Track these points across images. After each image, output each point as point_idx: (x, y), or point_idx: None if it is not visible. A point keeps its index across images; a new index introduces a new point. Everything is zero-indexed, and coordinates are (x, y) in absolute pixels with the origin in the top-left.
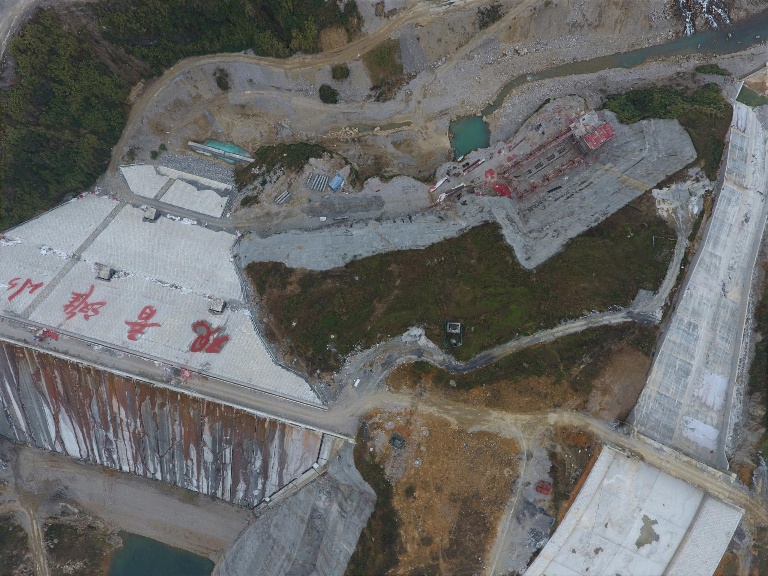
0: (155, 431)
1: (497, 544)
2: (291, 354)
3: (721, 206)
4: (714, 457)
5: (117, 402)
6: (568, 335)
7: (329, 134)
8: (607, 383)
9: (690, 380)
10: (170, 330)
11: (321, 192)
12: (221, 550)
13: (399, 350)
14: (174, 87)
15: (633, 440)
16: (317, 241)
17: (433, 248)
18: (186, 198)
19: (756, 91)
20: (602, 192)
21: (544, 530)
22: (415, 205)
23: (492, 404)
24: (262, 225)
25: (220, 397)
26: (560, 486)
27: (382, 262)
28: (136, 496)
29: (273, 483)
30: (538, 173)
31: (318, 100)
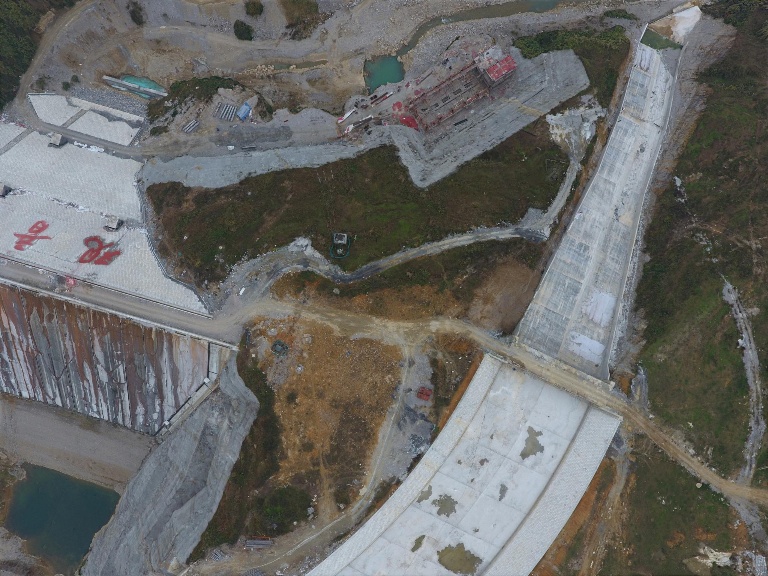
0: (47, 348)
1: (378, 450)
2: (180, 266)
3: (617, 136)
4: (599, 370)
5: (6, 316)
6: (454, 248)
7: (245, 71)
8: (489, 292)
9: (579, 298)
10: (60, 243)
11: (229, 122)
12: (126, 481)
13: (285, 260)
14: (86, 18)
15: (514, 348)
16: (216, 162)
17: (327, 166)
18: (95, 127)
19: (661, 35)
20: (502, 121)
21: (424, 436)
22: (323, 136)
23: (374, 311)
24: (170, 153)
25: (104, 305)
26: (440, 392)
27: (275, 178)
28: (37, 423)
29: (170, 404)
30: (445, 106)
31: (233, 36)
